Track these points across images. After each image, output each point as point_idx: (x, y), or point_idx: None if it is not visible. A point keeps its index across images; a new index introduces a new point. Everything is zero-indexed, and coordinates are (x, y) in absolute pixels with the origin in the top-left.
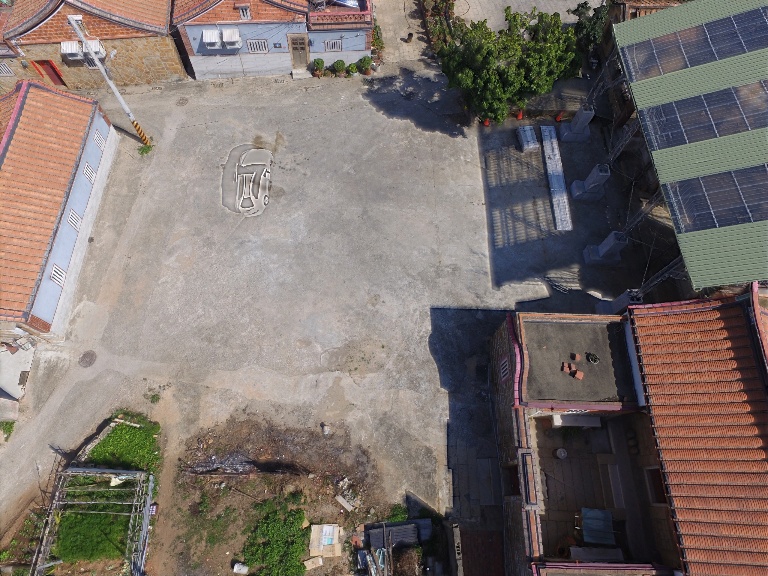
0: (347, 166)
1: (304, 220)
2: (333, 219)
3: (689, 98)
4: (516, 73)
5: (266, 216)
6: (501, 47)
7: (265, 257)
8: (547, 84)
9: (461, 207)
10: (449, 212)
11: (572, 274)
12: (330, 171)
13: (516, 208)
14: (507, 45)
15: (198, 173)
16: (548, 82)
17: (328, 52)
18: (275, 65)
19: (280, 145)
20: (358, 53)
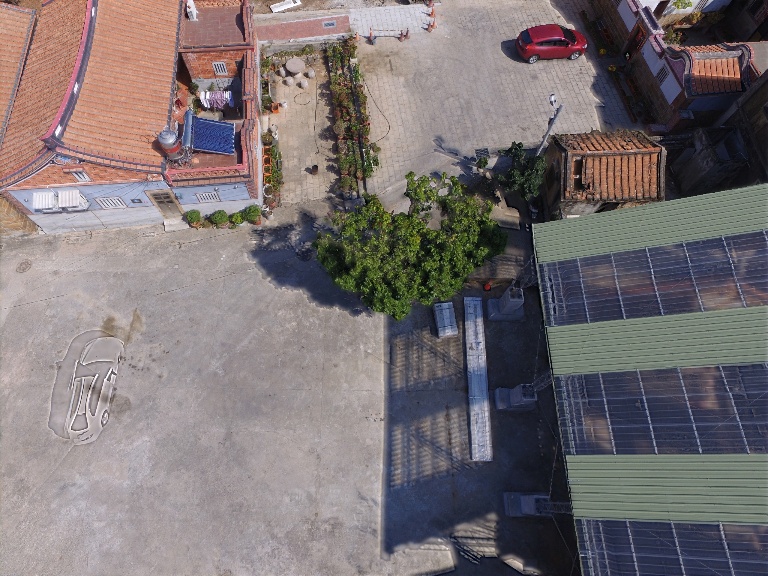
0: (215, 362)
1: (149, 449)
2: (186, 447)
3: (621, 372)
4: (406, 284)
5: (101, 443)
6: (385, 252)
7: (90, 510)
8: (452, 288)
9: (353, 425)
10: (336, 433)
11: (487, 531)
12: (192, 371)
13: (423, 425)
14: (393, 250)
15: (25, 376)
16: (453, 286)
17: (204, 203)
18: (141, 217)
19: (135, 331)
20: (242, 202)
